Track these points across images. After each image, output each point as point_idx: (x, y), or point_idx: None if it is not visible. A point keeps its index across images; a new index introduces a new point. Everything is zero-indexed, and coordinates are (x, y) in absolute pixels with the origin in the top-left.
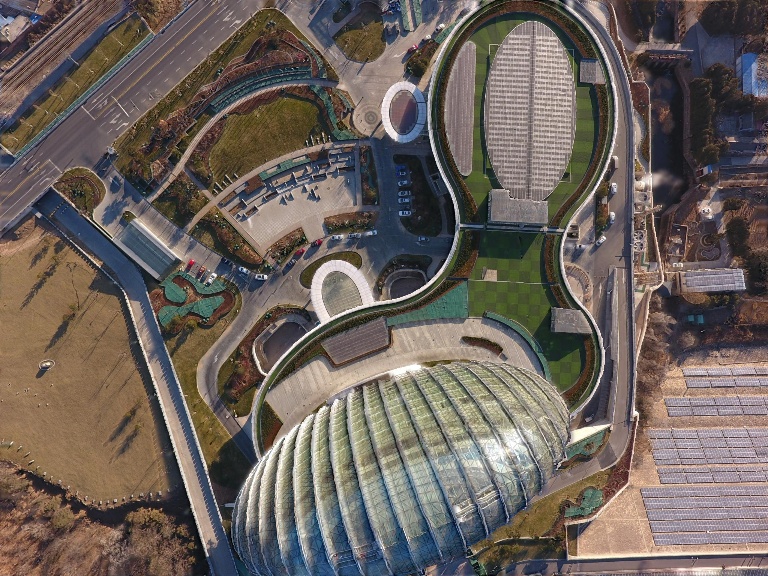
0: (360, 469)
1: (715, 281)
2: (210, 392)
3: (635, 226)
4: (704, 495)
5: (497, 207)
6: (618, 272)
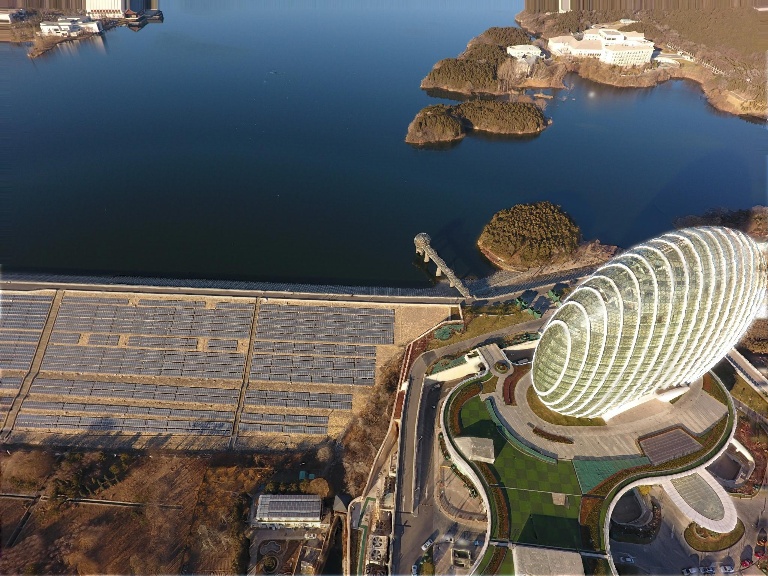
0: (734, 275)
1: (290, 506)
2: (767, 427)
3: (376, 571)
4: (347, 337)
5: (577, 571)
6: (410, 508)
